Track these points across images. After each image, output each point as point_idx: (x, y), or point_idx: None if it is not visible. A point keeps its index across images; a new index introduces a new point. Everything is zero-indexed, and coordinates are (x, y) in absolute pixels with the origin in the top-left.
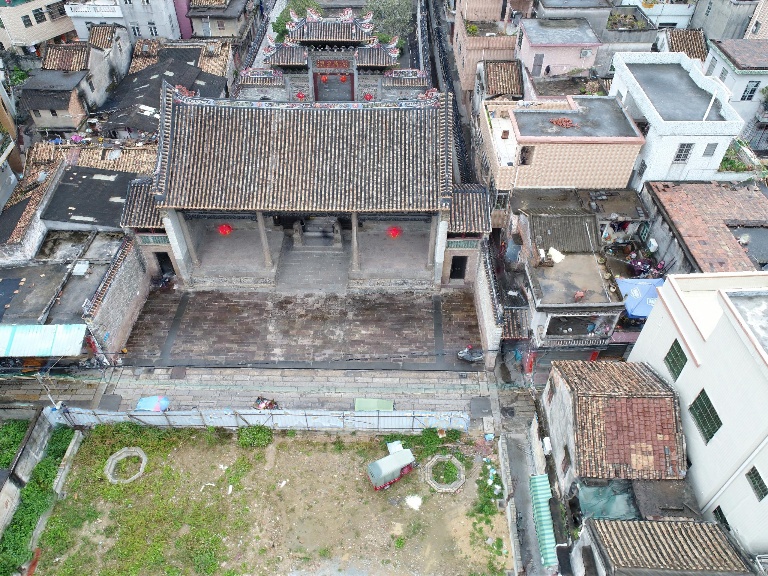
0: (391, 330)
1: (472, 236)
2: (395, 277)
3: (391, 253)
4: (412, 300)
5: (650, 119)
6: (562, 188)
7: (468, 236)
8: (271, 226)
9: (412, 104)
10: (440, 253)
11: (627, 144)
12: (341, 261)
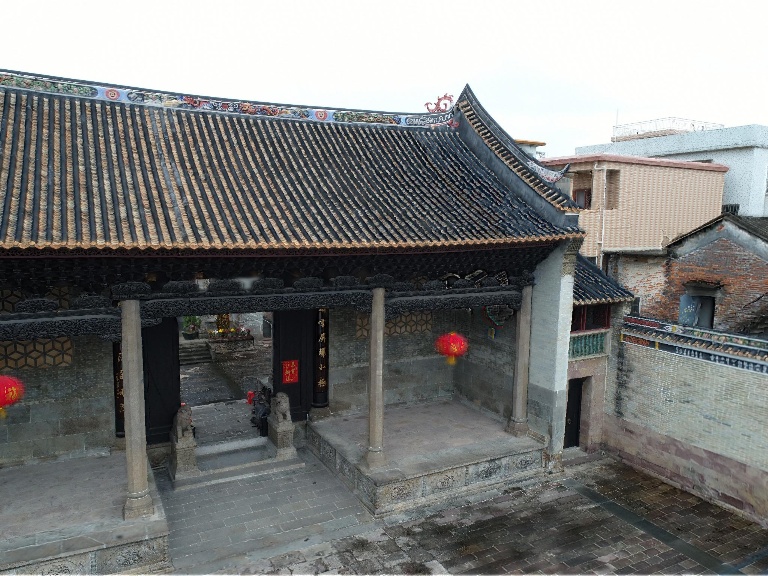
0: (569, 565)
1: (591, 328)
2: (474, 457)
3: (420, 431)
4: (534, 499)
5: (716, 144)
6: (657, 249)
7: (586, 328)
8: (107, 440)
9: (416, 120)
10: (561, 364)
11: (712, 172)
12: (312, 479)
